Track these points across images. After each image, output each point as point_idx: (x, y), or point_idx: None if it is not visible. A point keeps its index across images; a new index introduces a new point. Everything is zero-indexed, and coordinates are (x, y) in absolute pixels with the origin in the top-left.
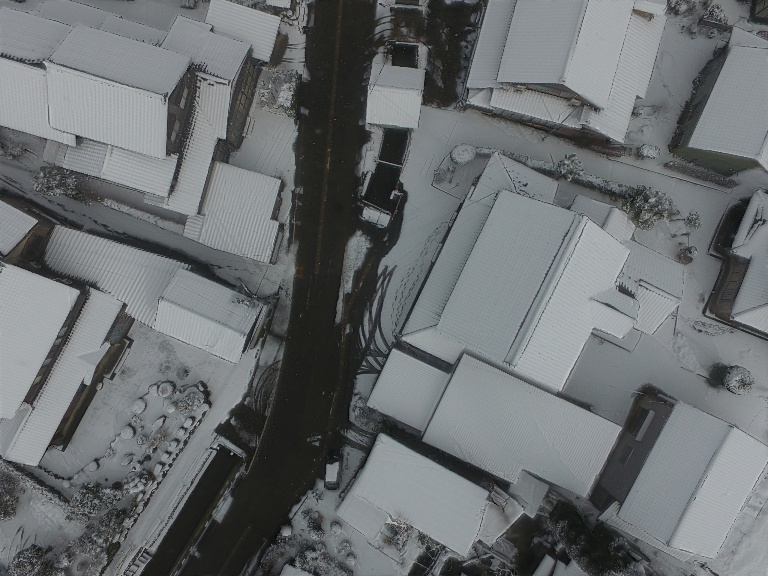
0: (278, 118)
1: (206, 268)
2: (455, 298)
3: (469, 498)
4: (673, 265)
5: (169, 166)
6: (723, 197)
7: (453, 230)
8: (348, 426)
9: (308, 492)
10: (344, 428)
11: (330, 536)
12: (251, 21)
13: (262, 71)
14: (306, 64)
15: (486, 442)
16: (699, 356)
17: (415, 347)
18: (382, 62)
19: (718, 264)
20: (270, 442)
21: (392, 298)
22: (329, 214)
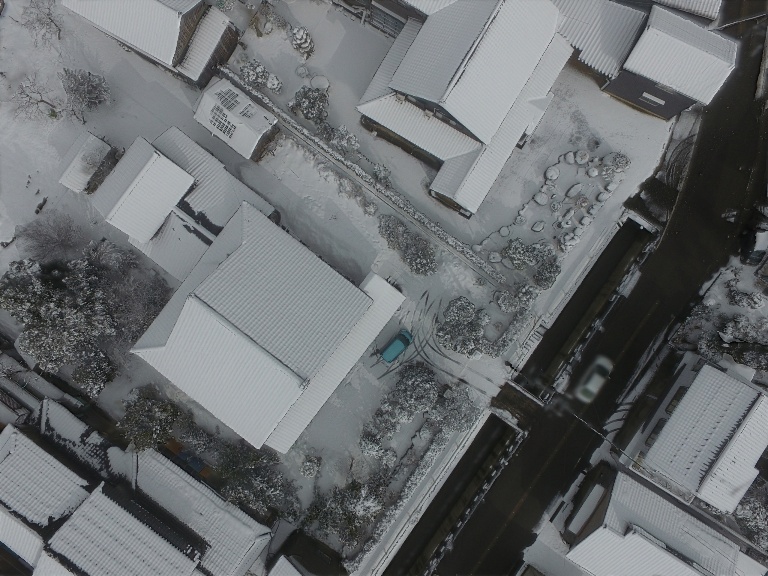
0: None
1: None
2: None
3: None
4: None
5: None
6: None
7: None
8: (765, 203)
9: (721, 269)
10: (761, 205)
11: (747, 313)
12: None
13: None
14: None
15: None
16: None
17: None
18: None
19: None
20: (682, 217)
21: None
22: None
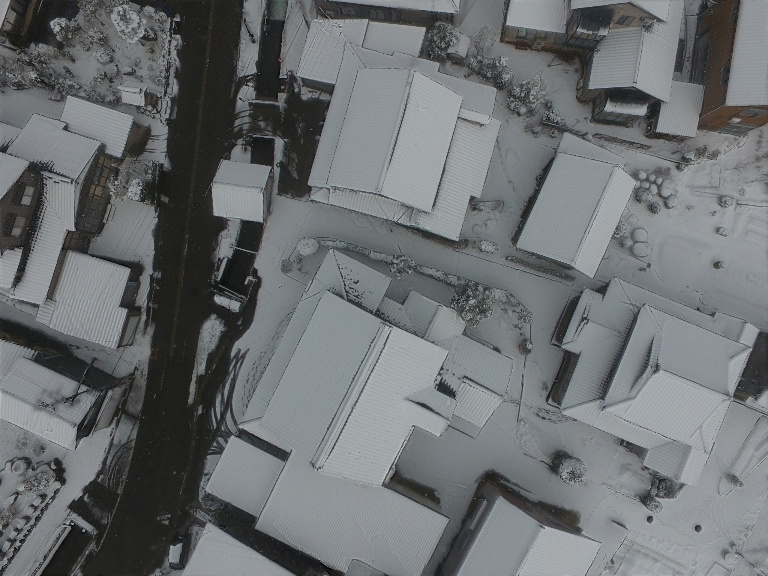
0: (138, 205)
1: (64, 348)
2: (278, 394)
3: None
4: (502, 361)
5: (13, 259)
6: (565, 289)
7: (291, 322)
8: (198, 506)
9: (156, 571)
10: (194, 508)
11: None
12: (104, 119)
13: (124, 161)
14: (168, 154)
15: (306, 536)
16: (540, 444)
17: (253, 434)
18: (240, 153)
19: (561, 354)
20: (121, 520)
21: (244, 381)
22: (185, 298)
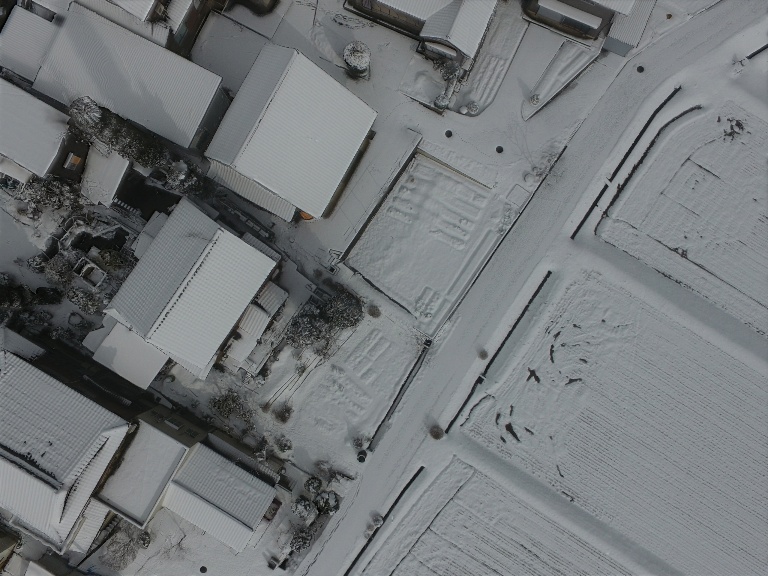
0: None
1: None
2: None
3: (51, 123)
4: None
5: None
6: None
7: None
8: None
9: None
10: None
11: None
12: None
13: None
14: None
15: (66, 65)
16: (334, 43)
17: (35, 3)
18: None
19: None
20: None
21: None
22: None
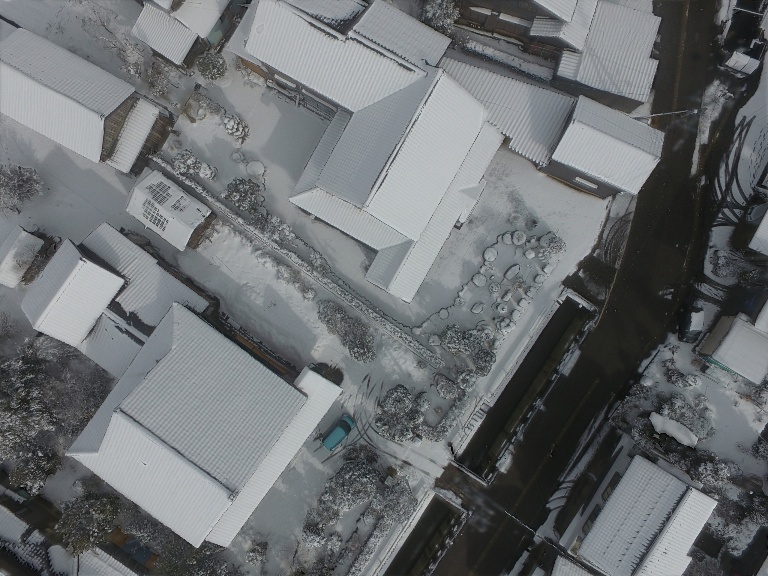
0: None
1: None
2: None
3: None
4: None
5: None
6: None
7: None
8: (702, 279)
9: (659, 346)
10: (698, 281)
11: (685, 390)
12: None
13: None
14: None
15: None
16: None
17: None
18: None
19: None
20: (620, 295)
21: (750, 149)
22: (687, 63)
